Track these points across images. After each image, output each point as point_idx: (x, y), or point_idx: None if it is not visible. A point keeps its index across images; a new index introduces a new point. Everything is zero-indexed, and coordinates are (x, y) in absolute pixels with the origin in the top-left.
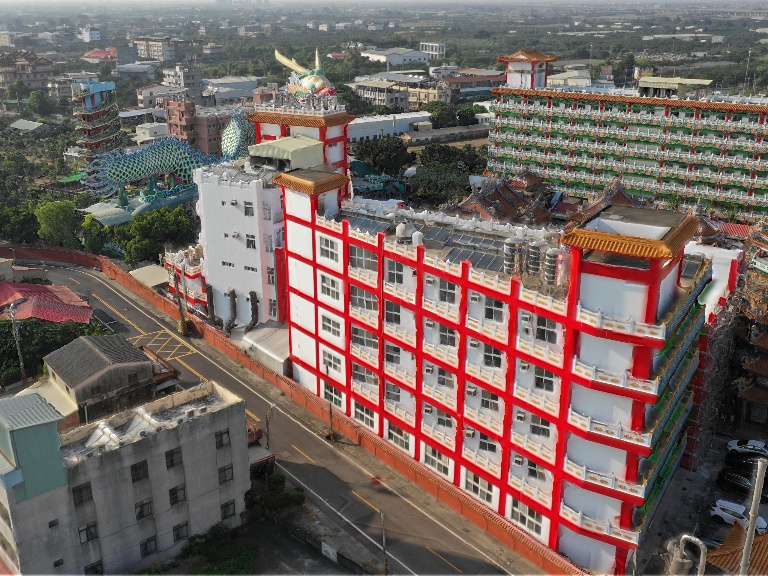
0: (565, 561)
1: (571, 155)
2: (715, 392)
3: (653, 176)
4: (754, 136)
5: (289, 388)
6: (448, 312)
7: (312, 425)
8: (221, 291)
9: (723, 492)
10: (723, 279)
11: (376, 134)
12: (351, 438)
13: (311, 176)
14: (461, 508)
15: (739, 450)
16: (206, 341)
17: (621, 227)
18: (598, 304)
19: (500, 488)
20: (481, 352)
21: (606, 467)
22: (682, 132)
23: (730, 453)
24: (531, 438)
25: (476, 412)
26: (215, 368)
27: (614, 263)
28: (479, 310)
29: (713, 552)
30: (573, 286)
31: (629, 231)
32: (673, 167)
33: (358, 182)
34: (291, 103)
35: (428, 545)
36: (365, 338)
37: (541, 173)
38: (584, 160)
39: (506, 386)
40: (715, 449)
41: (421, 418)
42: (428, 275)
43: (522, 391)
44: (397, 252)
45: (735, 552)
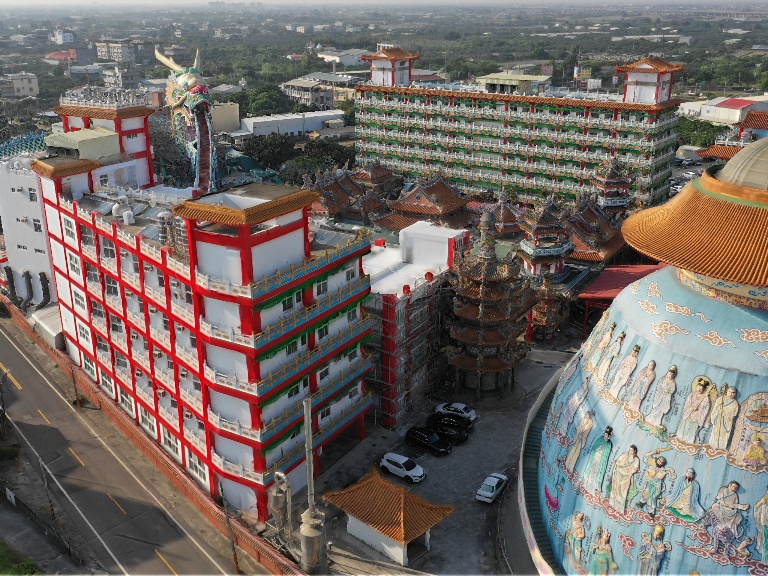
0: (209, 502)
1: (427, 149)
2: (426, 359)
3: (497, 168)
4: (581, 129)
5: (59, 360)
6: (135, 282)
7: (68, 393)
8: (19, 273)
9: (408, 448)
10: (444, 256)
11: (287, 132)
12: (96, 403)
13: (60, 162)
14: (156, 461)
15: (443, 412)
16: (13, 320)
17: (240, 201)
18: (211, 269)
19: (181, 441)
20: (160, 317)
21: (239, 416)
22: (520, 126)
23: (433, 414)
24: (193, 393)
25: (161, 372)
26: (7, 344)
27: (220, 232)
28: (152, 279)
29: (332, 492)
30: (190, 253)
31: (245, 204)
32: (514, 160)
33: (241, 176)
34: (98, 97)
35: (110, 492)
36: (103, 310)
37: (400, 166)
38: (438, 154)
39: (171, 347)
40: (425, 412)
41: (135, 381)
42: (123, 249)
43: (180, 350)
44: (103, 229)
45: (351, 491)
